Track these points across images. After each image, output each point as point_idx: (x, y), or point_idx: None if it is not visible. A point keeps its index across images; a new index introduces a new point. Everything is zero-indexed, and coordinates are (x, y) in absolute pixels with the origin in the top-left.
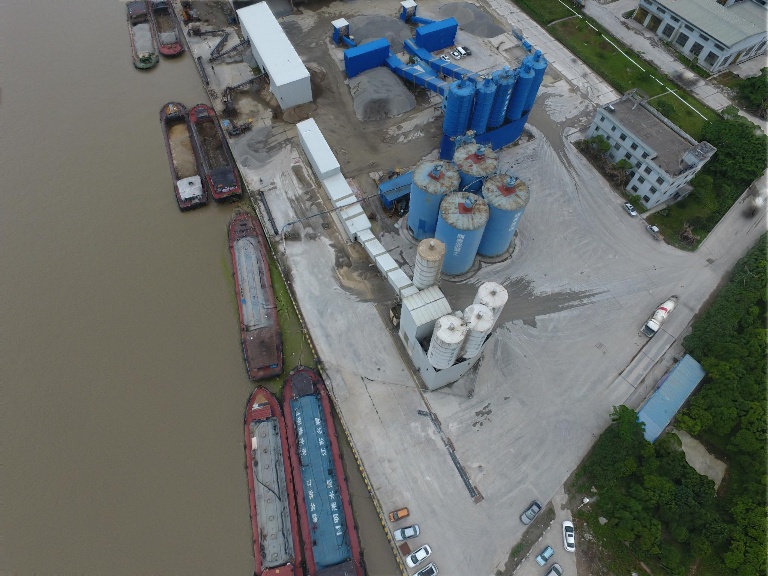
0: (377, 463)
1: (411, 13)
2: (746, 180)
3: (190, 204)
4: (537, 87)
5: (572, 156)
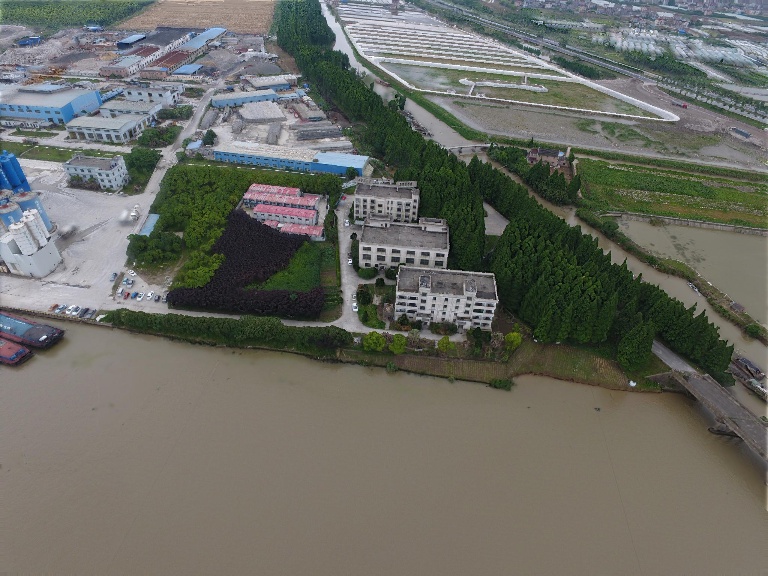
0: (31, 305)
1: None
2: (152, 165)
3: None
4: (18, 167)
5: (68, 191)
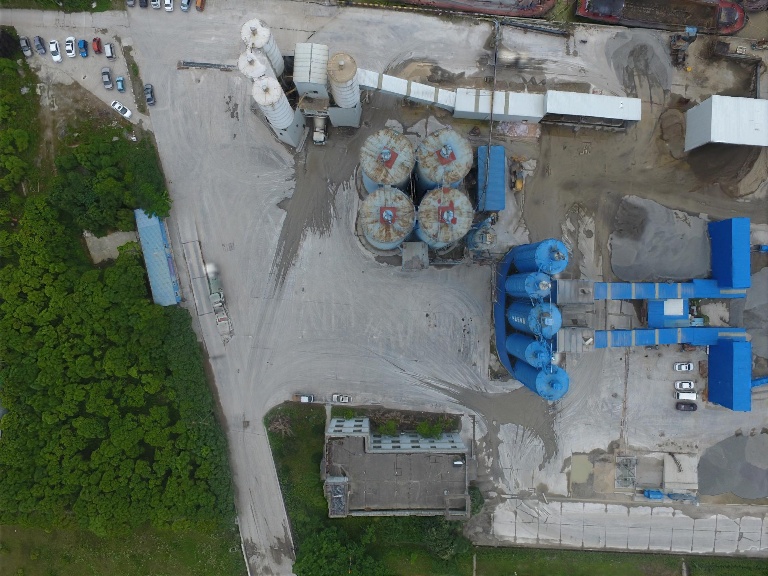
0: (244, 8)
1: None
2: None
3: None
4: None
5: (443, 399)
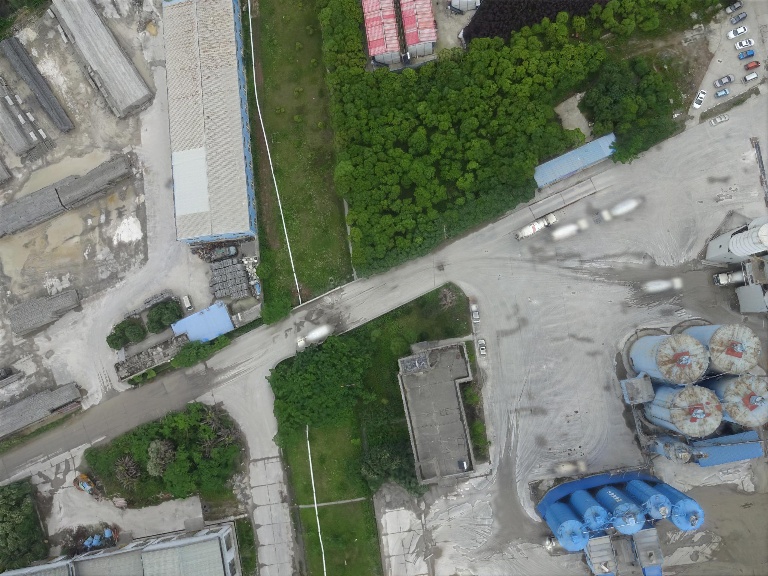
0: None
1: None
2: None
3: None
4: None
5: (501, 441)
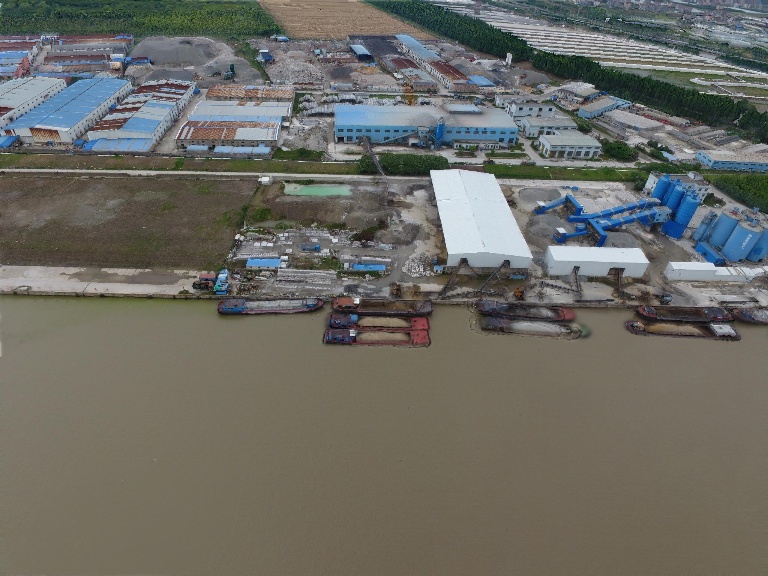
0: None
1: (539, 208)
2: None
3: (736, 334)
4: None
5: None
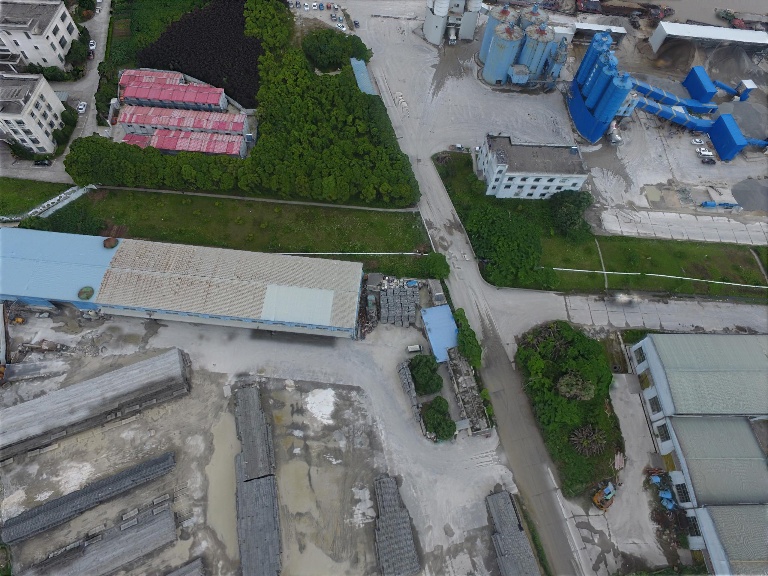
0: (406, 0)
1: None
2: None
3: None
4: (605, 99)
5: None
